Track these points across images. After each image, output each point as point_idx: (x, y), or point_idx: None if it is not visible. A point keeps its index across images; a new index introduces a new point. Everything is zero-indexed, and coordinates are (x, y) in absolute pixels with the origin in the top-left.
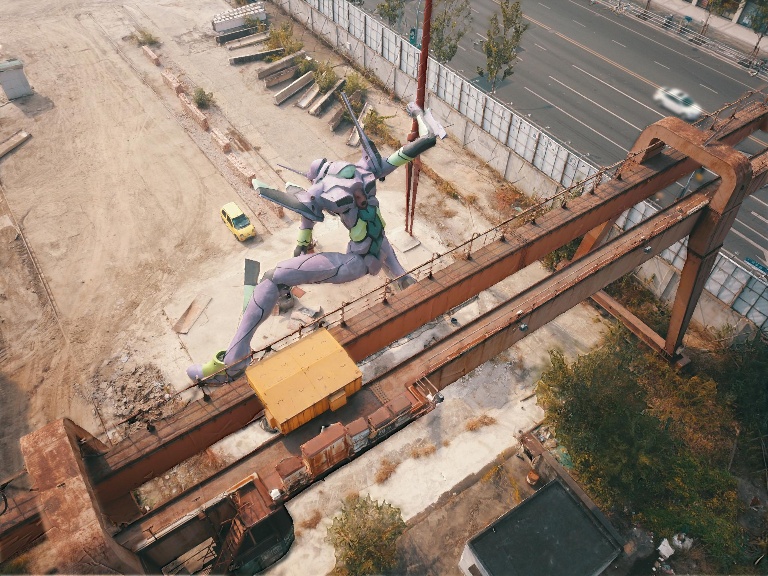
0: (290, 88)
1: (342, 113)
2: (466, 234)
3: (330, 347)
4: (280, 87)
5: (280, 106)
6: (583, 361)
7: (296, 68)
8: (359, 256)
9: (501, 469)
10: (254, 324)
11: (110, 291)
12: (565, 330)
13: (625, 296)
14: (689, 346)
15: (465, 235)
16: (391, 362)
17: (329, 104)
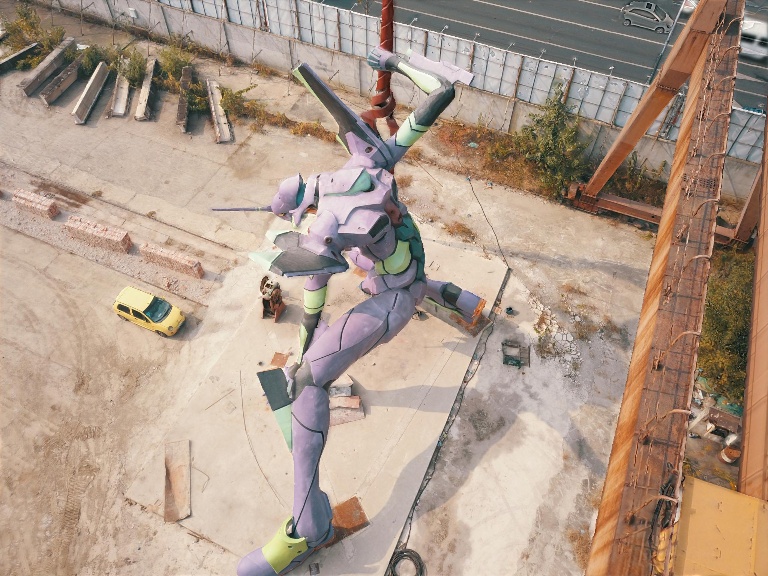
0: (87, 94)
1: (186, 104)
2: (440, 198)
3: (741, 510)
4: (68, 98)
5: (87, 124)
6: (734, 296)
7: (77, 64)
8: (402, 290)
9: (690, 463)
10: (317, 458)
11: (15, 515)
12: (621, 263)
13: (649, 197)
14: (735, 223)
15: (440, 200)
16: (481, 401)
17: (155, 98)
